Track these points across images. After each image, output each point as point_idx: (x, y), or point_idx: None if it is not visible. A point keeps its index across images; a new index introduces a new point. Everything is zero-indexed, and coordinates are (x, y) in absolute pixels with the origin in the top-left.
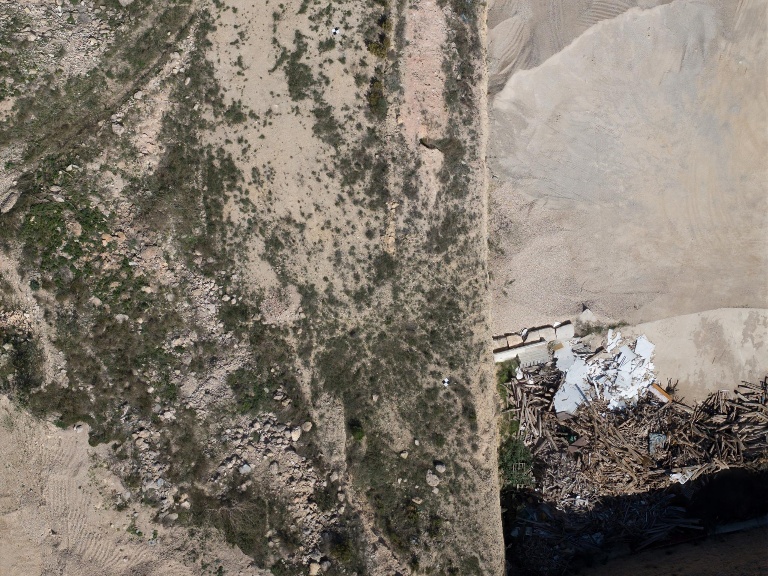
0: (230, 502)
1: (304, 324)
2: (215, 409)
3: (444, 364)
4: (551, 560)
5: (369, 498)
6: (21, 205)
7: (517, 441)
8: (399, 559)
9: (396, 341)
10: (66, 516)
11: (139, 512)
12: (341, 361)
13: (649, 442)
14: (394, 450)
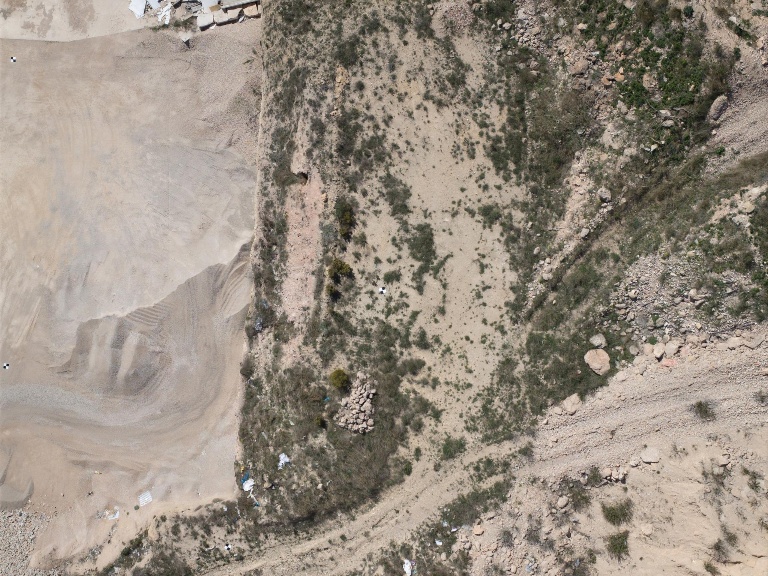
0: None
1: None
2: None
3: None
4: None
5: None
6: (704, 103)
7: None
8: None
9: None
10: None
11: None
12: None
13: None
14: None
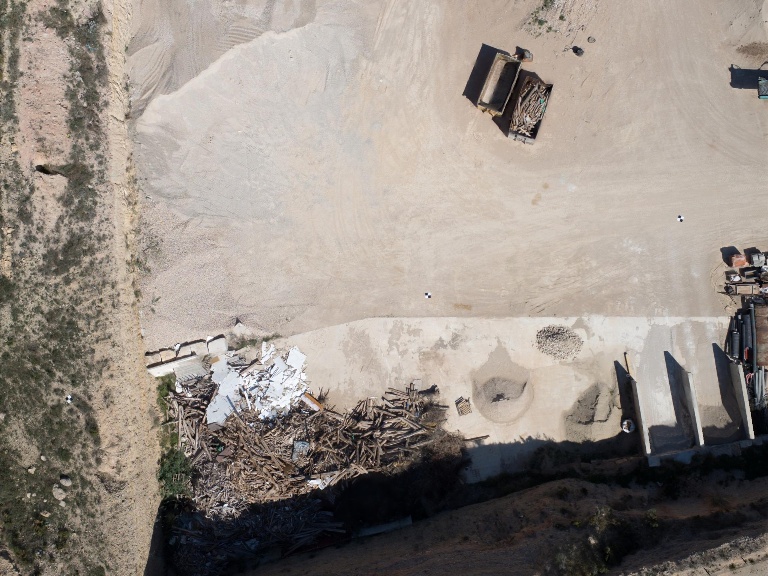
0: None
1: None
2: None
3: (66, 381)
4: (204, 567)
5: None
6: None
7: (178, 452)
8: (21, 571)
9: (20, 361)
10: None
11: None
12: None
13: (293, 450)
14: (23, 466)
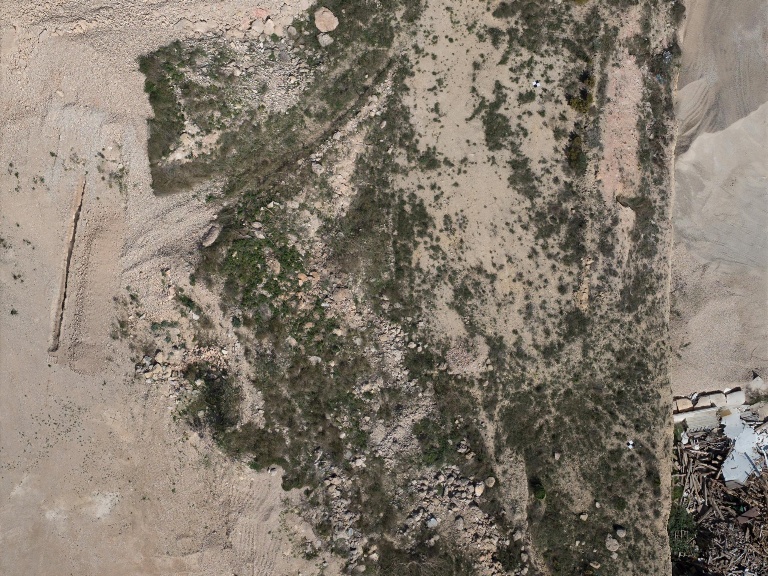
0: (419, 557)
1: (491, 376)
2: (402, 459)
3: (630, 426)
4: None
5: (546, 559)
6: (224, 240)
7: (679, 507)
8: None
9: (582, 399)
10: (252, 561)
11: (329, 562)
12: (524, 416)
13: None
14: (573, 511)
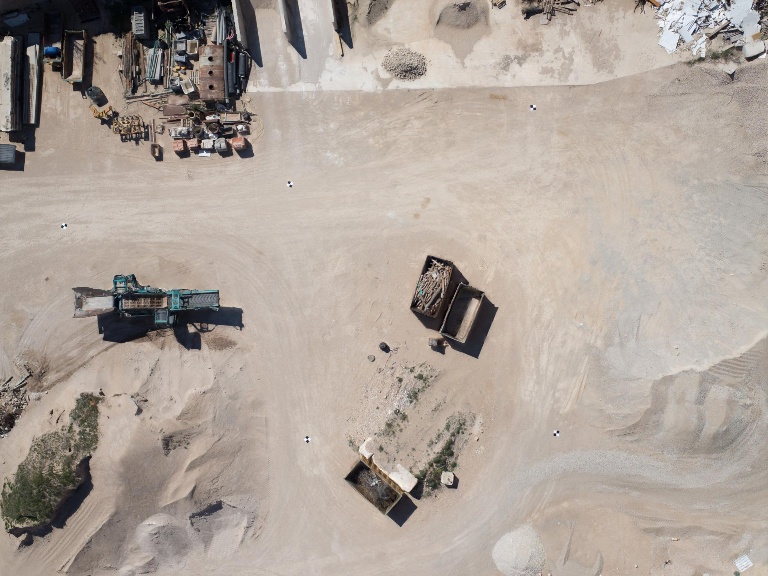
0: None
1: None
2: None
3: None
4: None
5: None
6: None
7: None
8: None
9: None
10: None
11: None
12: None
13: None
14: None
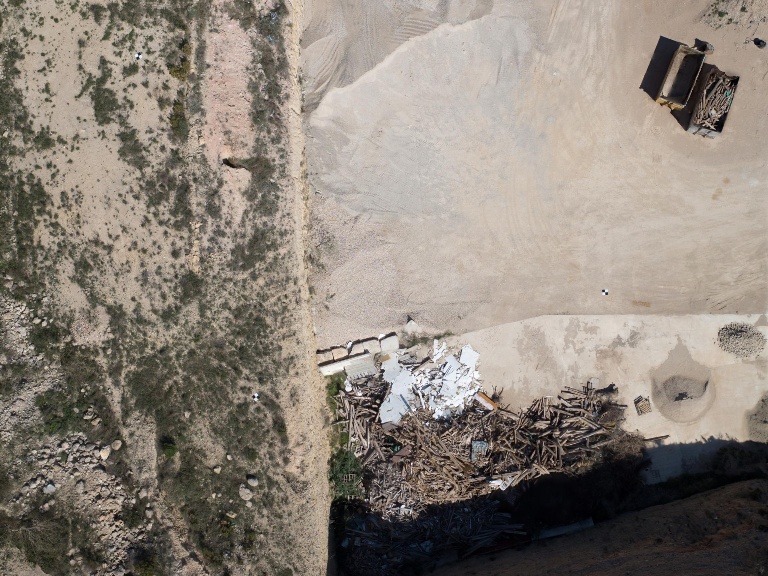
0: (31, 522)
1: (113, 344)
2: (21, 430)
3: (253, 379)
4: (379, 569)
5: (183, 514)
6: None
7: (348, 453)
8: (211, 573)
9: (206, 358)
10: None
11: None
12: (153, 379)
13: (471, 450)
14: (208, 465)
